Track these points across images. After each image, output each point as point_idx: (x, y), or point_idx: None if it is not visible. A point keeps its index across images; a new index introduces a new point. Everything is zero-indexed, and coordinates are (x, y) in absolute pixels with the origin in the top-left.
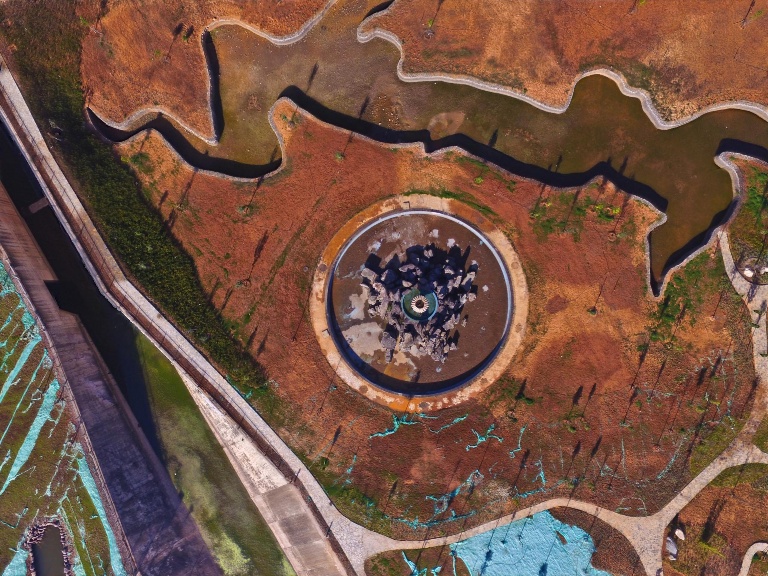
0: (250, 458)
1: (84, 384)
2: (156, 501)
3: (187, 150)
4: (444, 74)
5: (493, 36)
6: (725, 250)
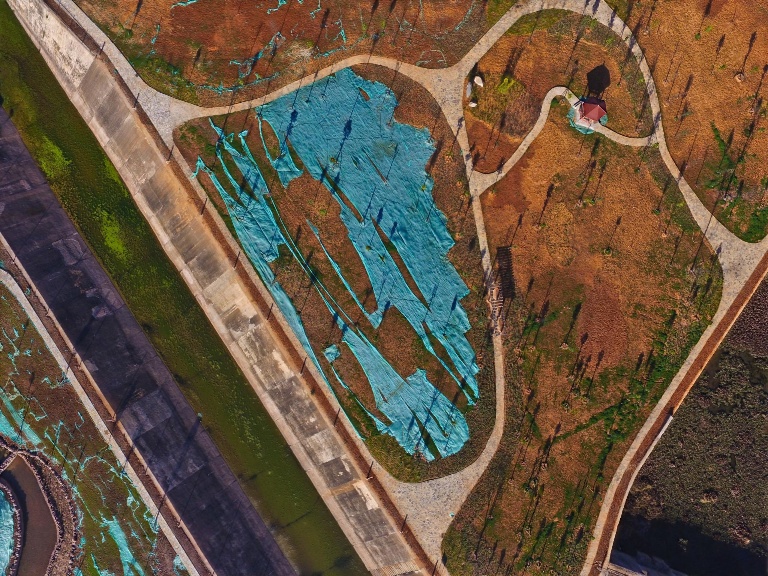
0: (59, 43)
1: None
2: None
3: None
4: None
5: None
6: None
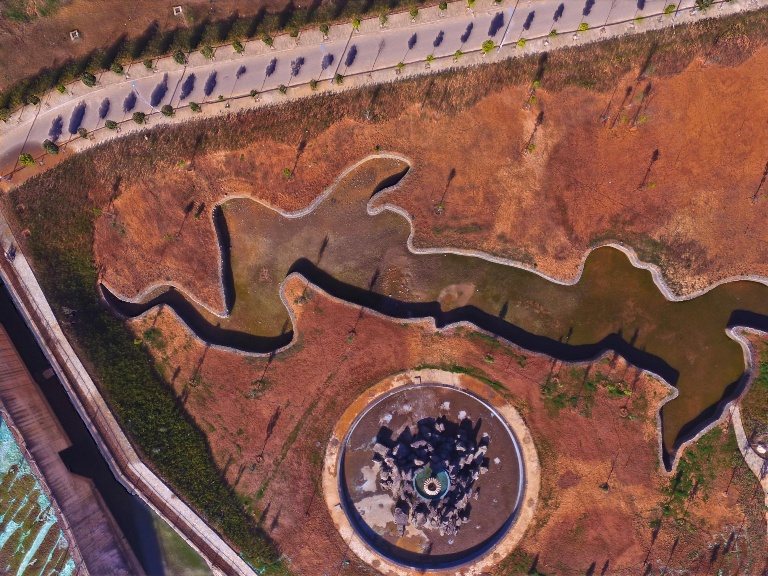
0: None
1: (99, 558)
2: None
3: (199, 322)
4: (454, 249)
5: (503, 212)
6: (737, 425)
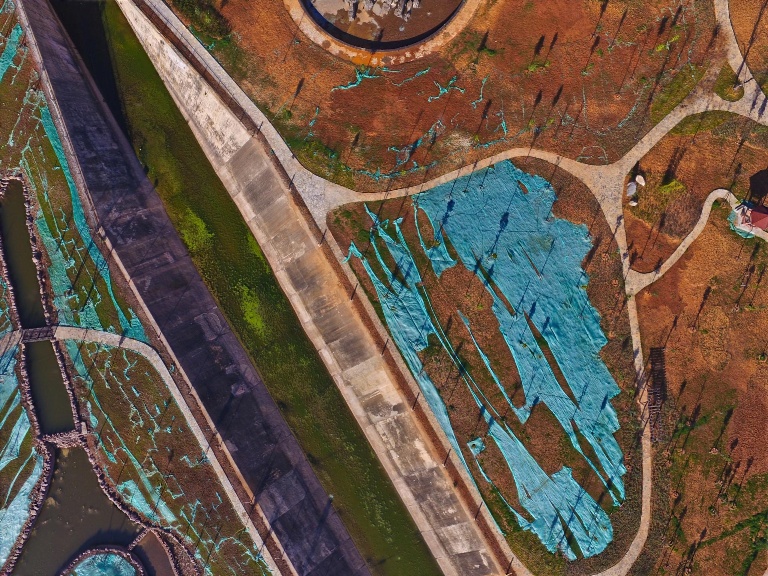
0: (213, 119)
1: (47, 39)
2: (120, 168)
3: None
4: None
5: None
6: None
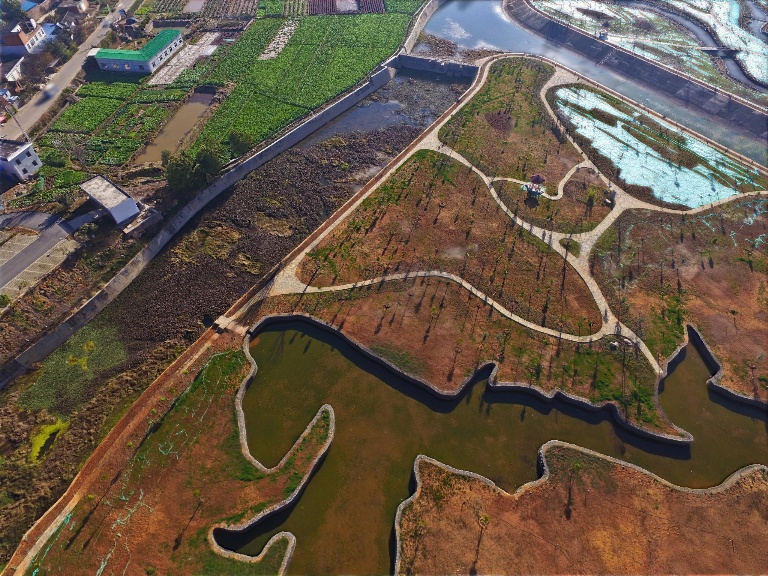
0: None
1: None
2: None
3: None
4: None
5: None
6: (652, 359)
